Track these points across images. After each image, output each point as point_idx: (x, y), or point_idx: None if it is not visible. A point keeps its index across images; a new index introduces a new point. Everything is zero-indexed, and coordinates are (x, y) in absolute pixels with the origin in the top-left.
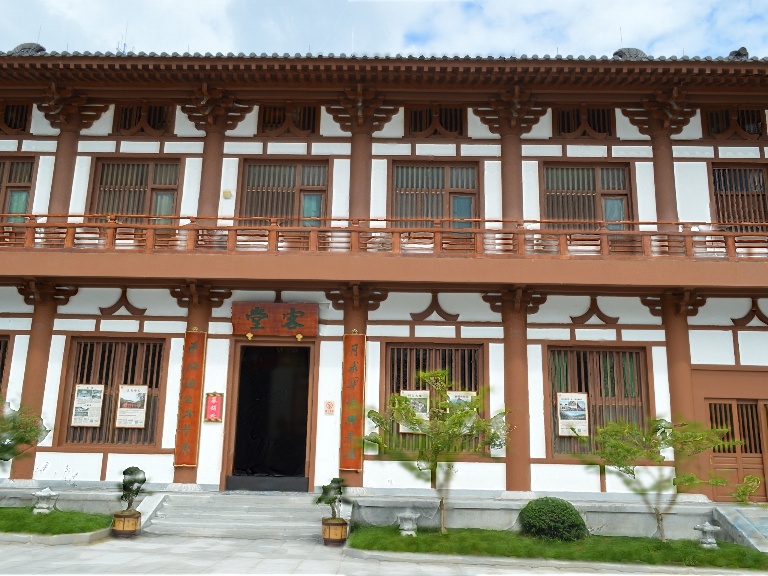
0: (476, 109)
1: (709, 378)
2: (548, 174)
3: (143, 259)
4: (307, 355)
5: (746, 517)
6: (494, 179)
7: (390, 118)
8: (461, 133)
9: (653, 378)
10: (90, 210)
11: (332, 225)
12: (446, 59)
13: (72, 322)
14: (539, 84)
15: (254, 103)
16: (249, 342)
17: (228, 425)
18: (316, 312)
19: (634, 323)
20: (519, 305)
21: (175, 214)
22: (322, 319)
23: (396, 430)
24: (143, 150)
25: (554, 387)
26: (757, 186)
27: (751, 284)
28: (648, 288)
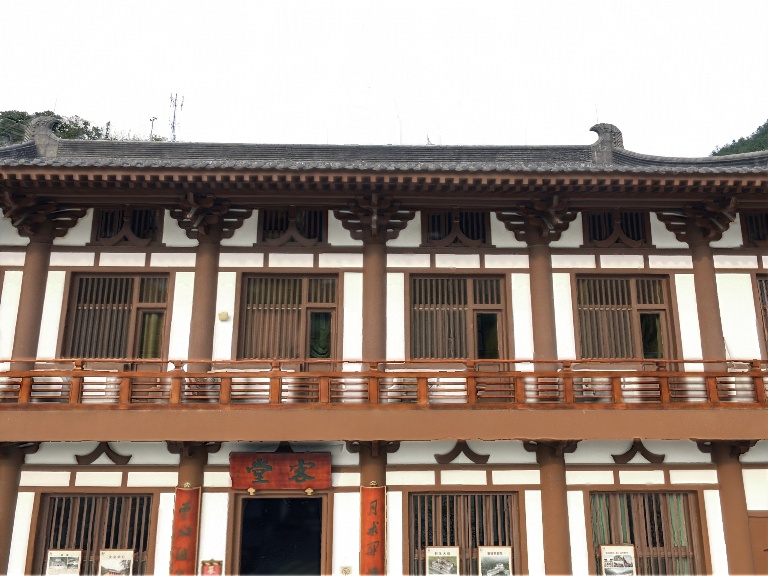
0: (500, 213)
1: (767, 526)
2: (579, 287)
3: (116, 418)
4: (318, 507)
5: None
6: (523, 295)
7: (406, 224)
8: (484, 241)
9: (707, 528)
10: (65, 335)
11: (344, 351)
12: (481, 170)
13: (42, 476)
14: (579, 193)
15: (253, 207)
16: (251, 495)
17: None
18: (328, 463)
19: (681, 461)
20: (561, 452)
21: (163, 340)
22: (335, 466)
23: None
24: (126, 263)
25: (596, 538)
26: None
27: None
28: None
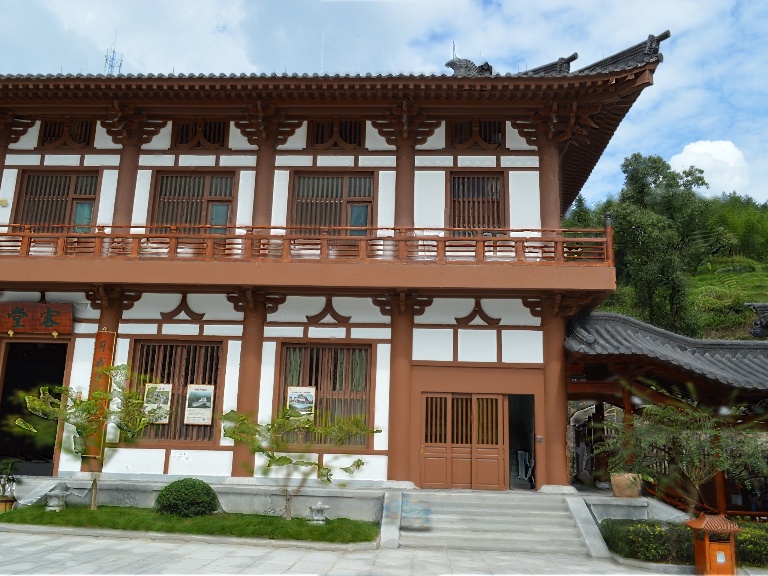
0: (237, 122)
1: (428, 373)
2: (300, 183)
3: None
4: (65, 351)
5: (407, 500)
6: (248, 188)
7: (158, 131)
8: (223, 145)
9: (376, 373)
10: None
11: (96, 231)
12: (182, 78)
13: None
14: (280, 99)
15: (35, 118)
16: (12, 339)
17: None
18: (70, 311)
19: (365, 322)
20: (252, 305)
21: None
22: (79, 318)
23: (139, 420)
24: None
25: (287, 381)
26: (494, 193)
27: (454, 285)
28: (365, 289)
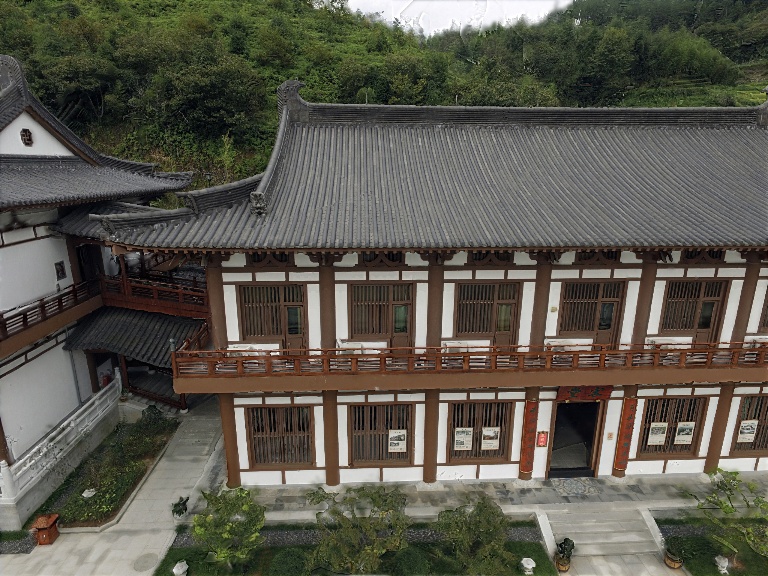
0: None
1: None
2: None
3: (518, 376)
4: (597, 406)
5: None
6: (736, 293)
7: None
8: (720, 258)
9: None
10: (456, 321)
11: (623, 328)
12: (760, 245)
13: (452, 395)
14: None
15: None
16: None
17: (550, 448)
18: (612, 388)
19: None
20: None
21: (516, 323)
22: None
23: (645, 443)
24: (492, 277)
25: (740, 417)
26: None
27: None
28: None
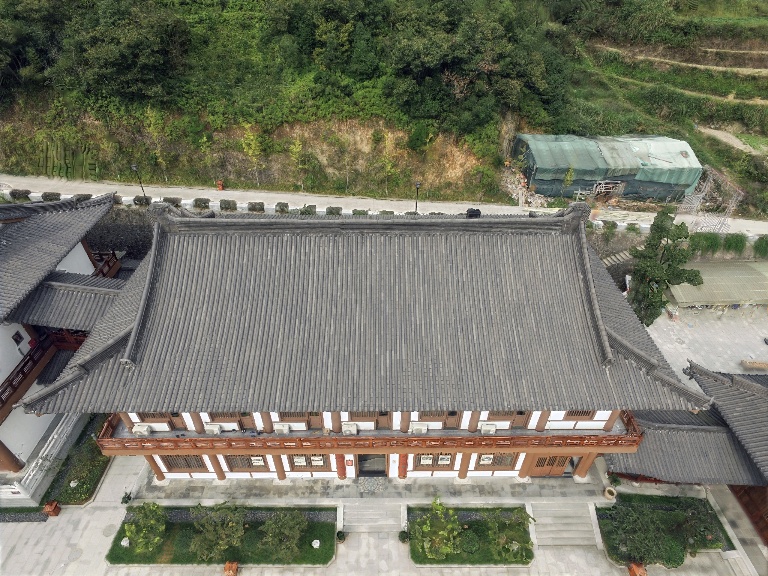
0: None
1: None
2: None
3: (317, 450)
4: None
5: None
6: None
7: None
8: None
9: None
10: (280, 414)
11: None
12: None
13: None
14: None
15: None
16: None
17: None
18: None
19: None
20: None
21: None
22: None
23: None
24: None
25: (481, 453)
26: None
27: None
28: None
